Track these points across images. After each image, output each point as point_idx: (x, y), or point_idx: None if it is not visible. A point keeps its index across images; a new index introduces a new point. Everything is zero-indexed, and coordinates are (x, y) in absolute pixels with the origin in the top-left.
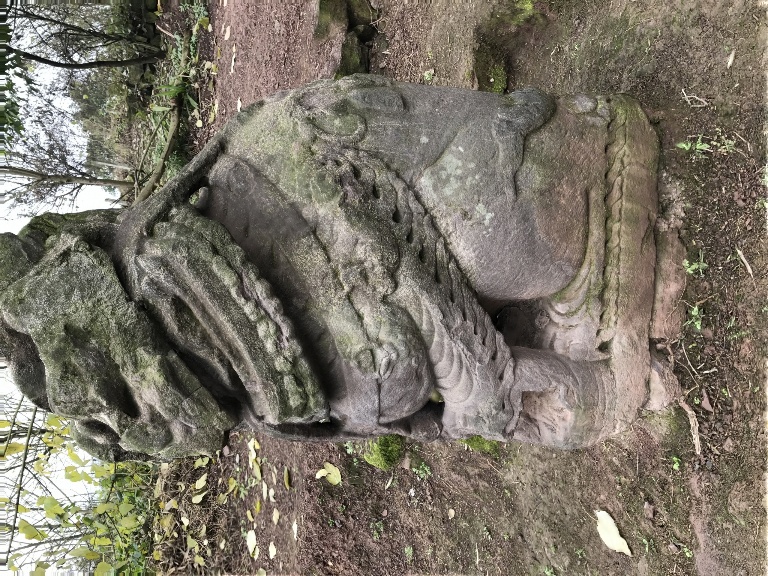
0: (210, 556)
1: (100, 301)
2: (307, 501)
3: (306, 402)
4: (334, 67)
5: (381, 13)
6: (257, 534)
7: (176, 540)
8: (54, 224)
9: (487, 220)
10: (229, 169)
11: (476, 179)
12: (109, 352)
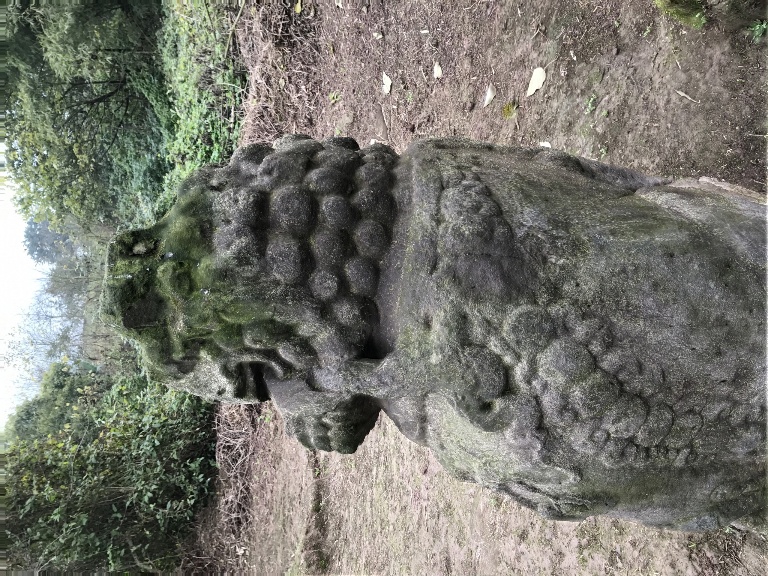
0: None
1: None
2: None
3: None
4: None
5: None
6: None
7: None
8: None
9: None
10: None
11: None
12: None
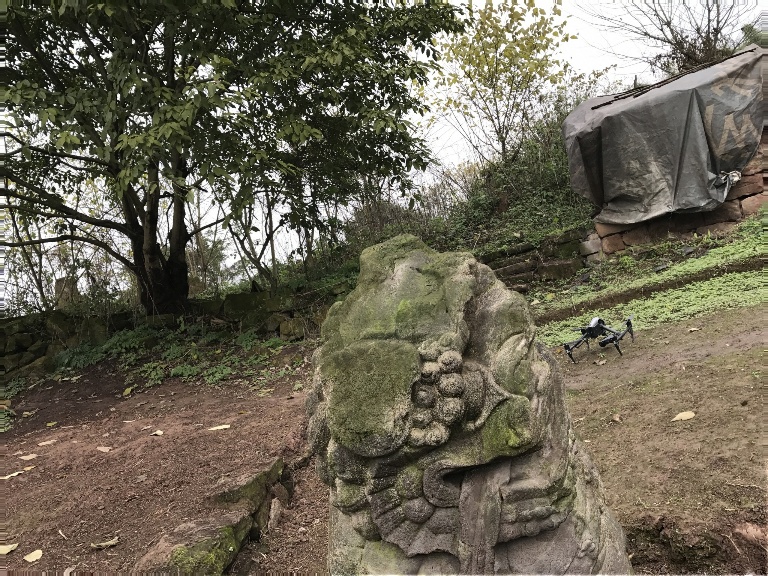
0: None
1: None
2: None
3: (562, 497)
4: (226, 522)
5: (268, 534)
6: None
7: None
8: None
9: (619, 554)
10: None
11: (616, 529)
12: None
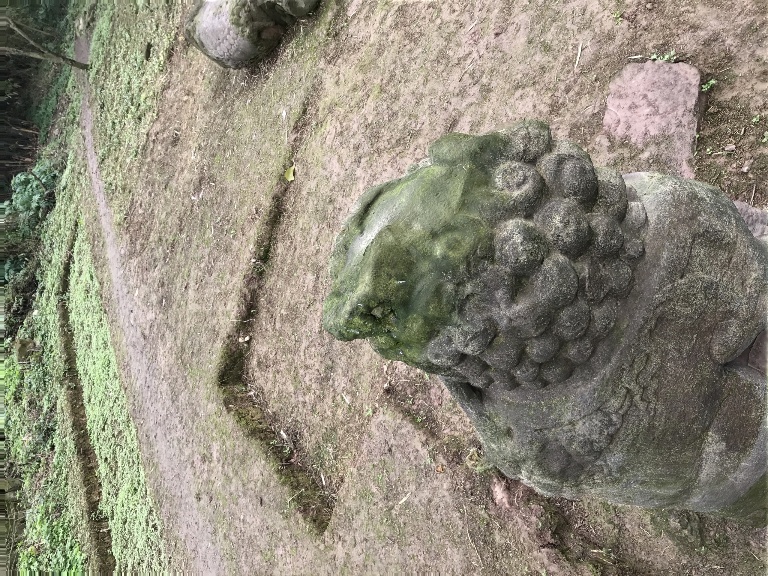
0: None
1: None
2: None
3: None
4: None
5: None
6: None
7: None
8: None
9: None
10: None
11: None
12: None
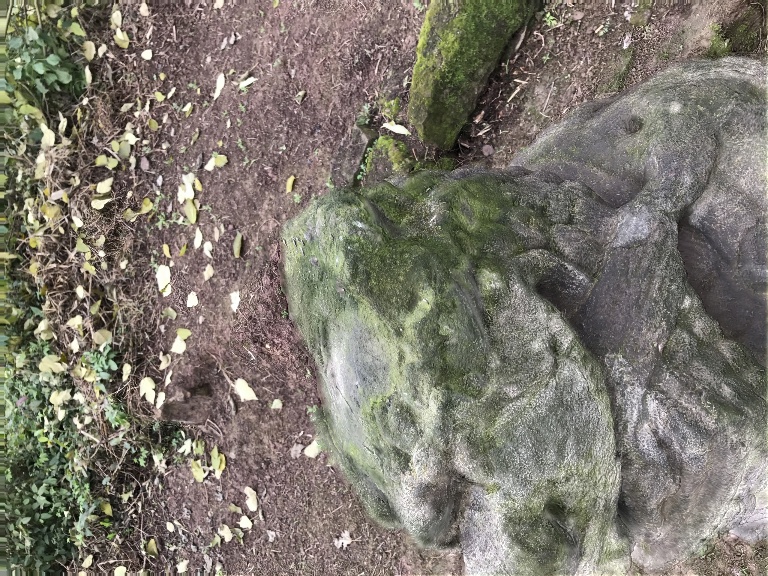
0: (105, 270)
1: (595, 468)
2: (265, 286)
3: None
4: None
5: None
6: (173, 273)
7: (62, 237)
8: (464, 222)
9: None
10: (748, 227)
11: None
12: (581, 544)
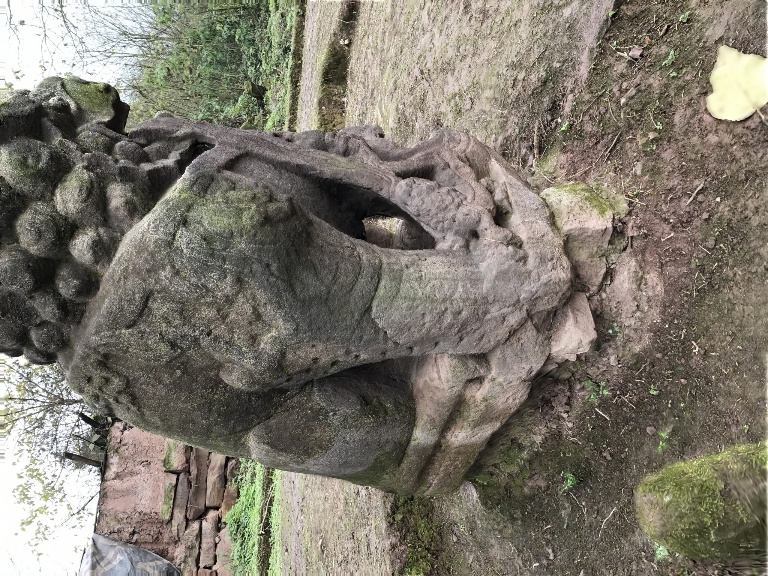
0: None
1: None
2: None
3: None
4: None
5: None
6: None
7: None
8: None
9: None
10: None
11: None
12: None
